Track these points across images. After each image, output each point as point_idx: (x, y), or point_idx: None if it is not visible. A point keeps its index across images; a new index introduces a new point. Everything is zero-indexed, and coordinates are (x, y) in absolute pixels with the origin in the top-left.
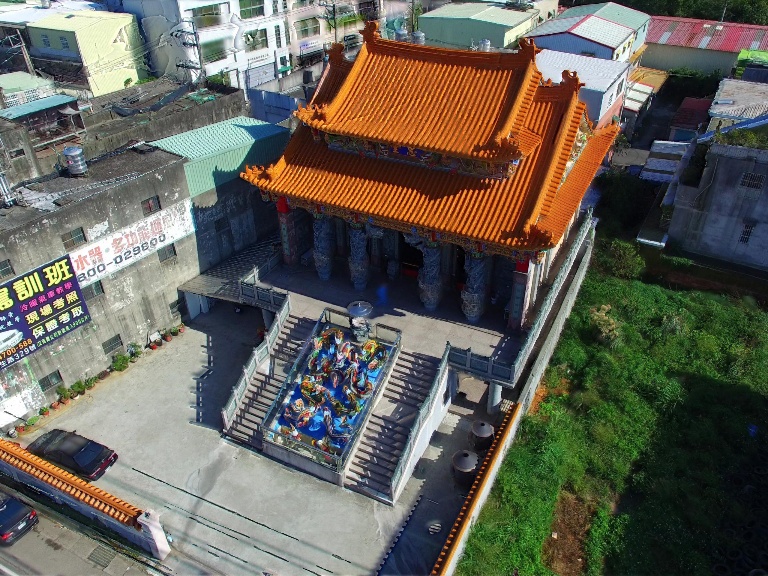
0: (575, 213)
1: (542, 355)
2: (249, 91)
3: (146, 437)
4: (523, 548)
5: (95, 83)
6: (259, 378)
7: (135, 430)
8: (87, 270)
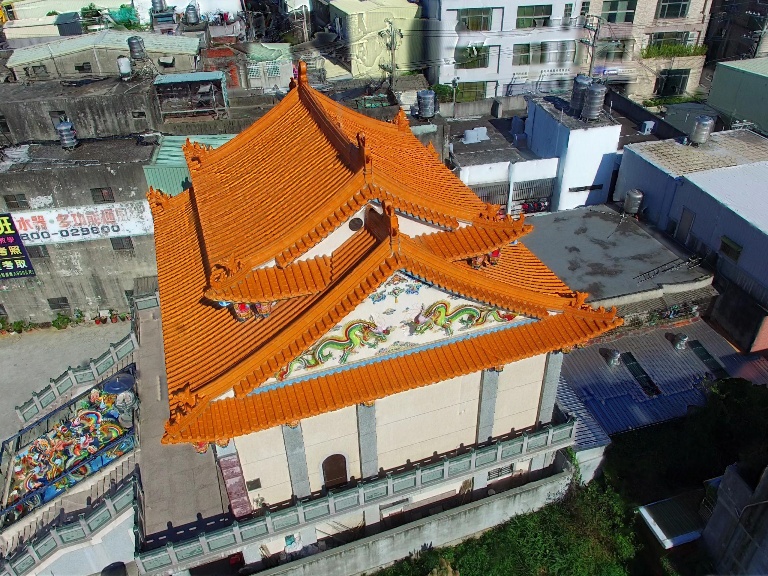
0: (537, 413)
1: (278, 569)
2: None
3: None
4: None
5: (358, 66)
6: (67, 398)
7: None
8: (31, 232)
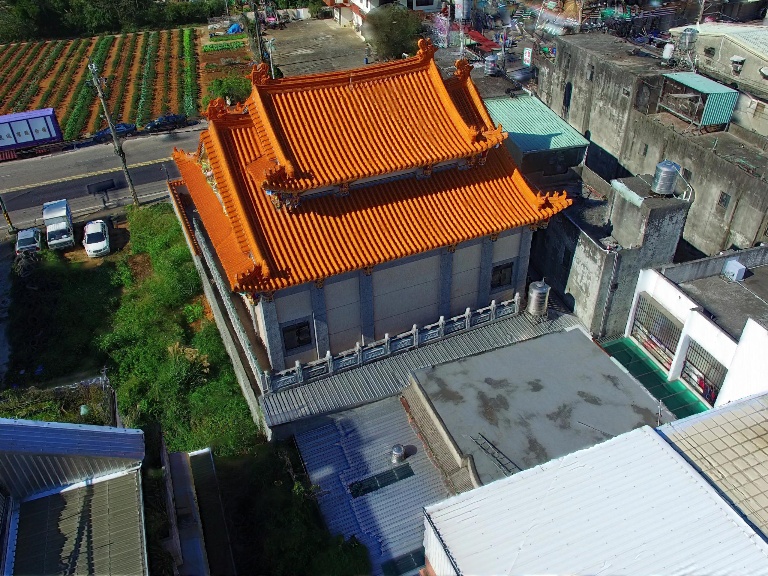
0: None
1: (208, 286)
2: None
3: None
4: (156, 242)
5: None
6: None
7: None
8: None
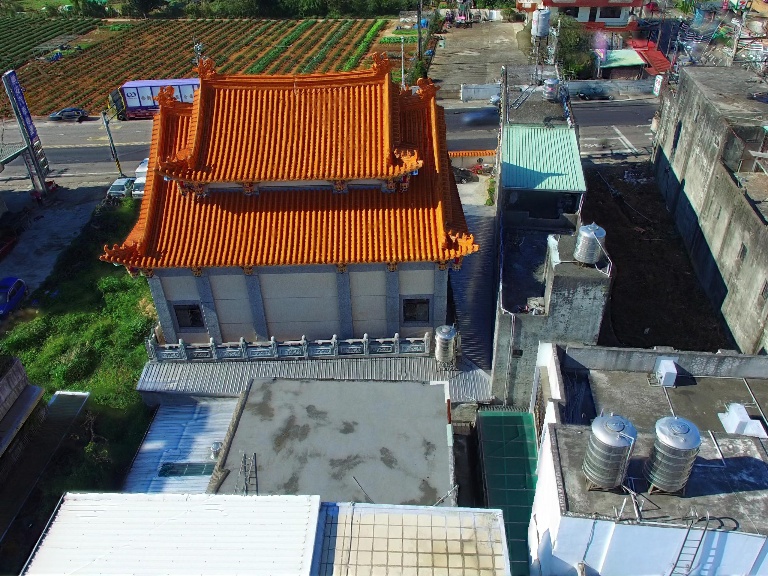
0: None
1: None
2: None
3: None
4: None
5: None
6: None
7: None
8: None
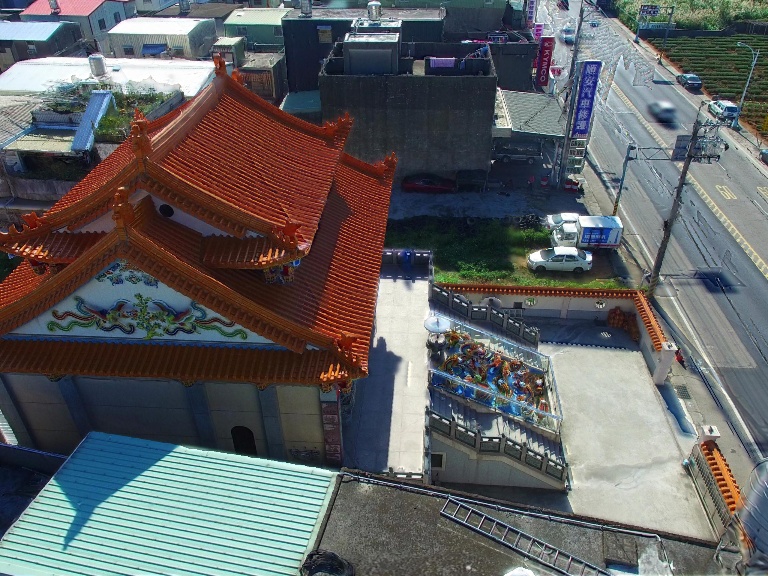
0: None
1: None
2: None
3: None
4: None
5: None
6: None
7: None
8: None
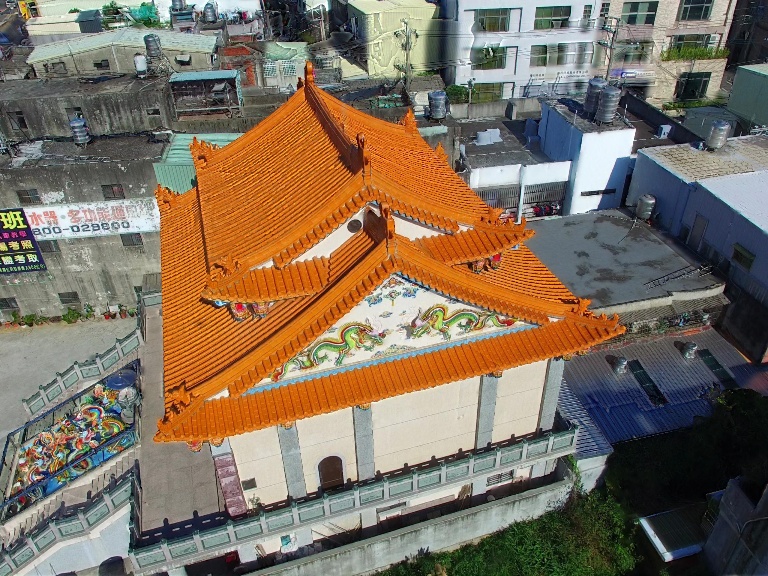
0: (538, 420)
1: (273, 569)
2: (424, 109)
3: (3, 386)
4: None
5: (374, 66)
6: (73, 392)
7: (7, 376)
8: (43, 227)
